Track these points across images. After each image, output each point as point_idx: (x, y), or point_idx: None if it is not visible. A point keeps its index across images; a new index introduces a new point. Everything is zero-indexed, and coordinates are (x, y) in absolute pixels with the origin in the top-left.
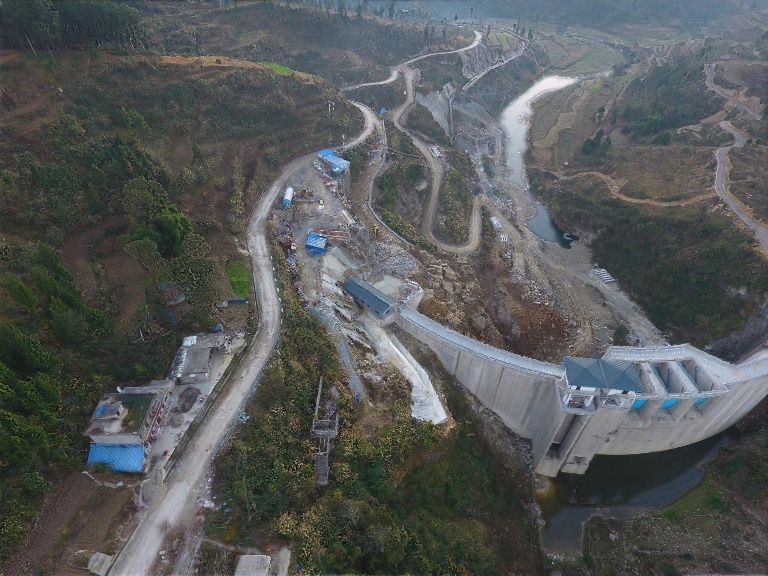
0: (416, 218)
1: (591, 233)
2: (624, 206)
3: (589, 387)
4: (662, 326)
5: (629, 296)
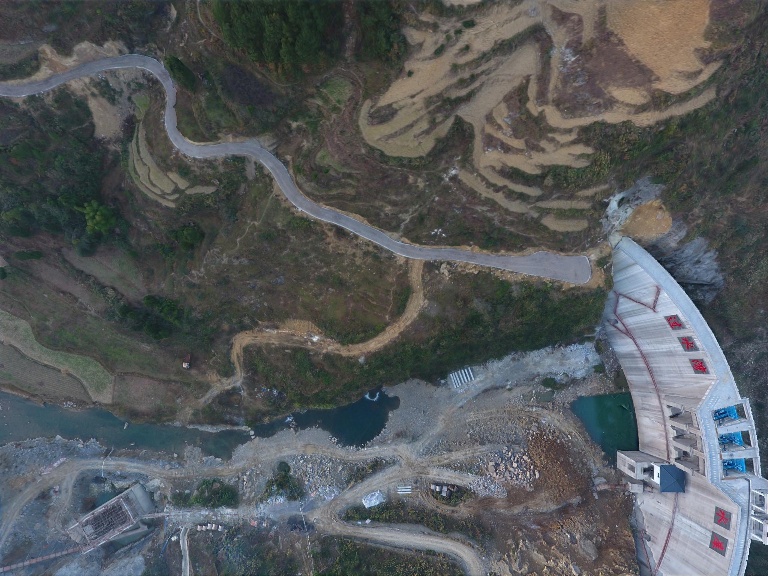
0: None
1: None
2: (394, 357)
3: None
4: None
5: (495, 359)
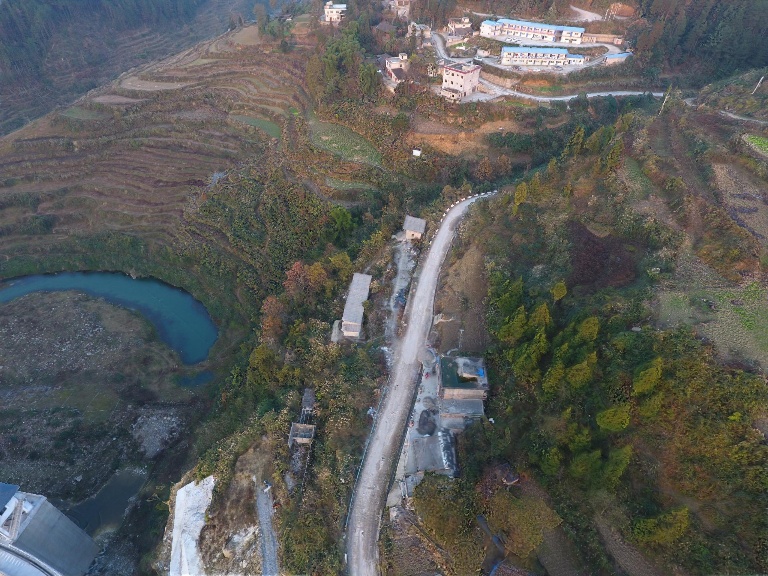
0: None
1: None
2: None
3: None
4: None
5: None
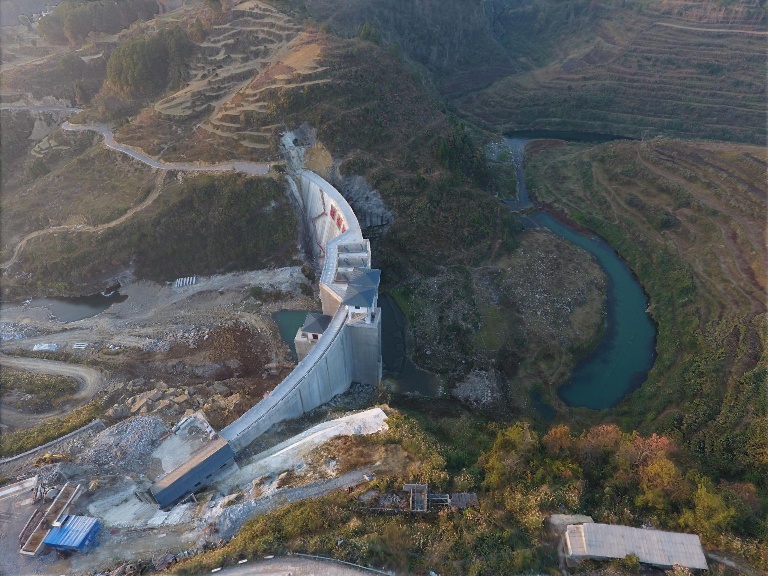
0: (0, 426)
1: (125, 271)
2: (124, 229)
3: (373, 297)
4: (263, 265)
5: (219, 274)
